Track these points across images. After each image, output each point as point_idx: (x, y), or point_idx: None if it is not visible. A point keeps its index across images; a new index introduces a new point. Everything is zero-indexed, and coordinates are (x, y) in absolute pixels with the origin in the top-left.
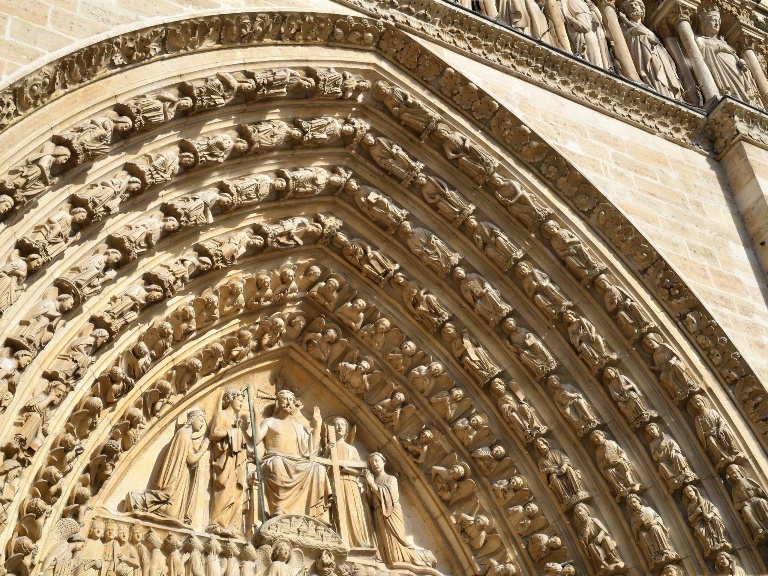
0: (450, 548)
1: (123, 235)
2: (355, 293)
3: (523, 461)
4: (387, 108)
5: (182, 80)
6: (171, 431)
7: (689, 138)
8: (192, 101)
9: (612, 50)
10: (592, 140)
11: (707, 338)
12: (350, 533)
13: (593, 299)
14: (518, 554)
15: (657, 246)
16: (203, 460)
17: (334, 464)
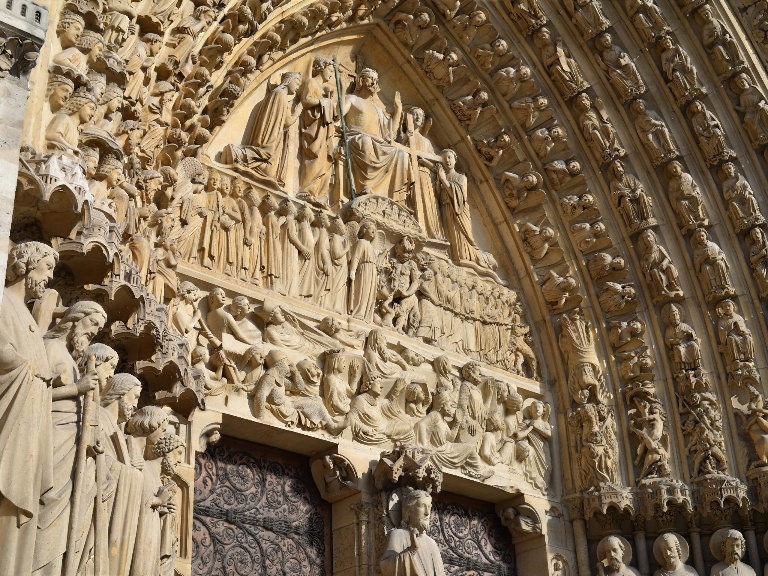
0: (508, 255)
1: None
2: None
3: (595, 180)
4: None
5: None
6: (263, 89)
7: None
8: None
9: None
10: None
11: None
12: (425, 224)
13: (691, 29)
14: (577, 270)
15: None
16: (292, 125)
17: (412, 153)
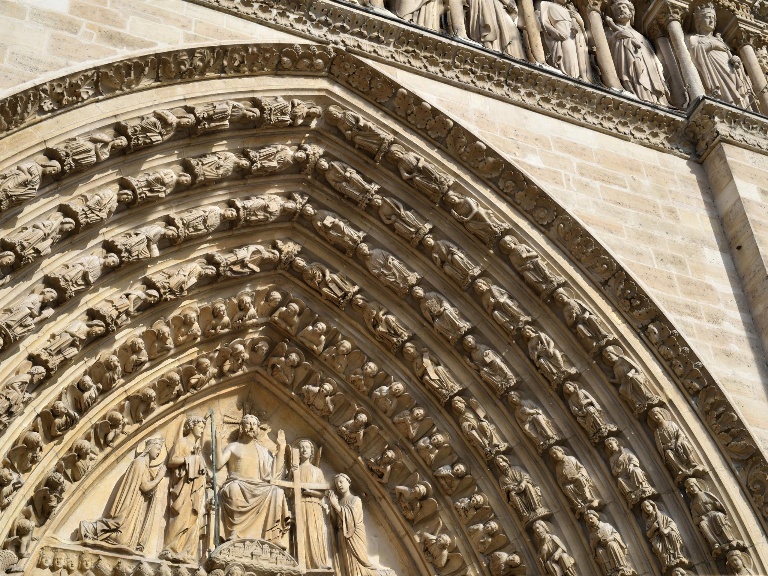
0: (415, 567)
1: (59, 274)
2: (315, 317)
3: (485, 479)
4: (341, 132)
5: (117, 120)
6: (130, 459)
7: (668, 142)
8: (127, 140)
9: (594, 56)
10: (556, 151)
11: (669, 349)
12: (308, 555)
13: (553, 313)
14: (480, 572)
15: (618, 257)
16: (161, 487)
17: (296, 487)
